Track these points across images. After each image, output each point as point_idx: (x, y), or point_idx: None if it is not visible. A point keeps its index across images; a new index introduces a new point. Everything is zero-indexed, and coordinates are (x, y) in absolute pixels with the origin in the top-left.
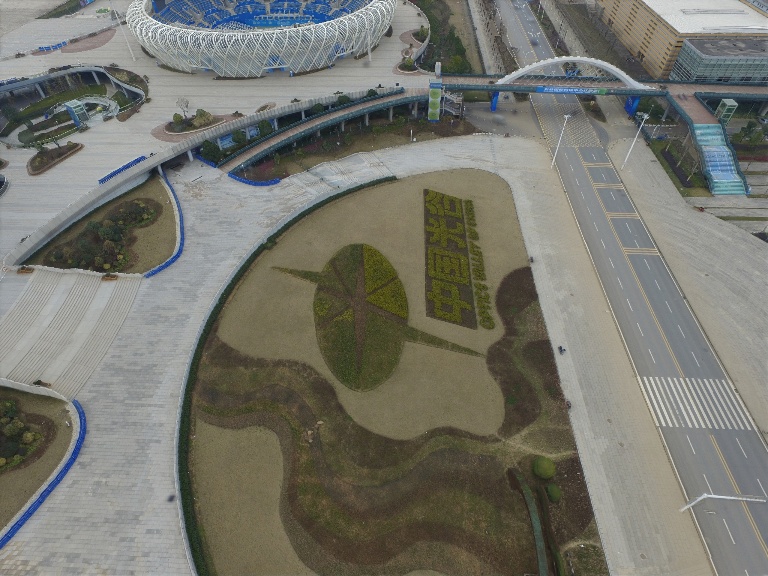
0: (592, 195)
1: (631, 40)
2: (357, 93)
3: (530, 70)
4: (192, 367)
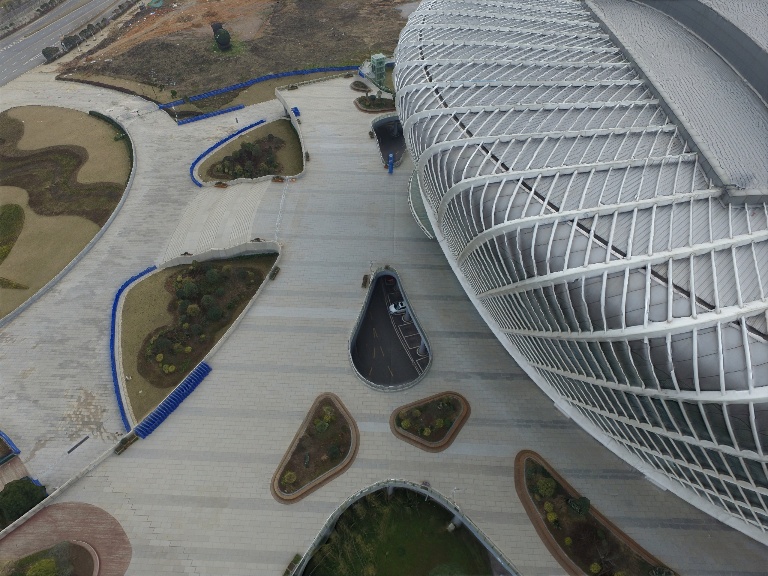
0: None
1: None
2: None
3: None
4: None
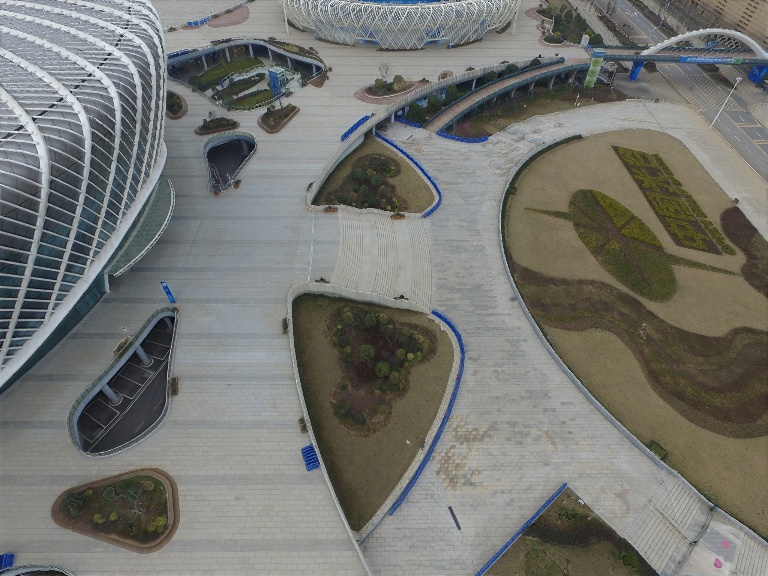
0: (757, 150)
1: (724, 19)
2: (522, 62)
3: (675, 41)
4: None
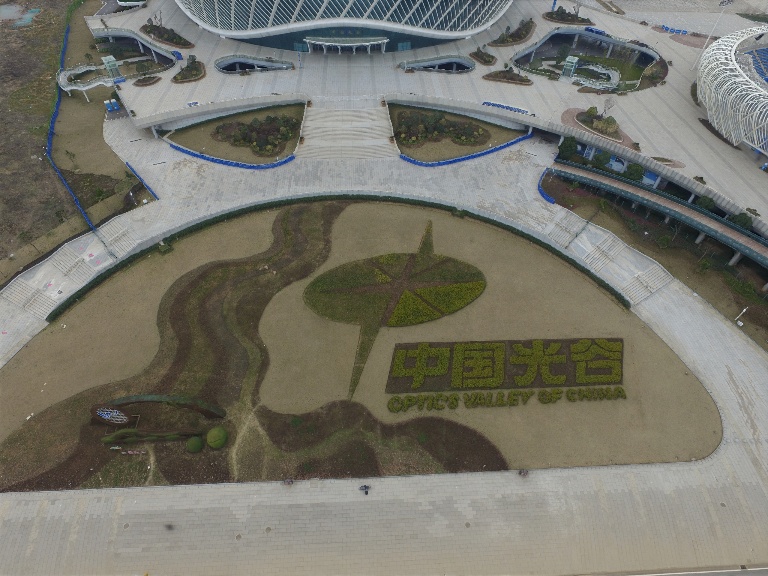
0: None
1: None
2: None
3: None
4: (319, 196)
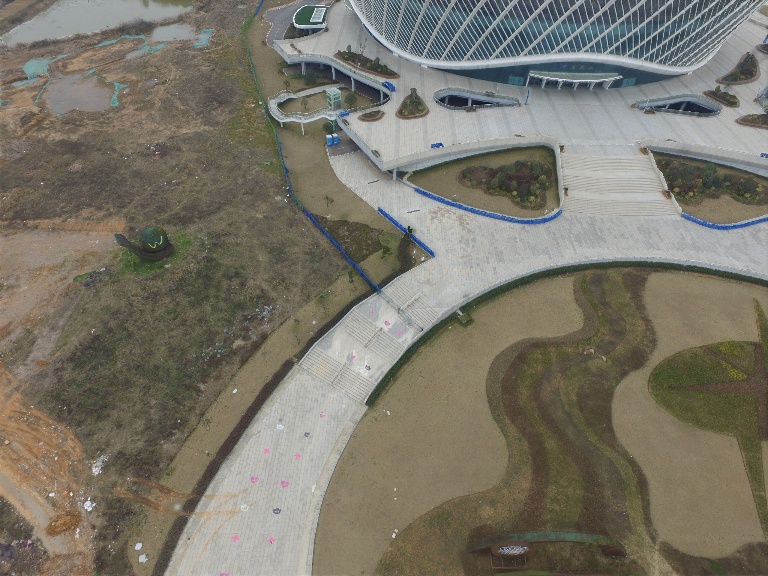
0: None
1: None
2: None
3: None
4: (614, 262)
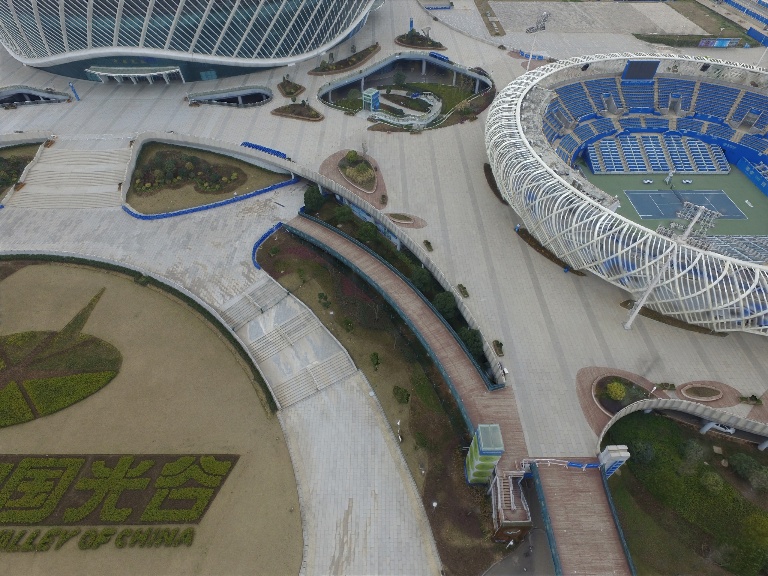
0: None
1: None
2: (469, 315)
3: None
4: None
